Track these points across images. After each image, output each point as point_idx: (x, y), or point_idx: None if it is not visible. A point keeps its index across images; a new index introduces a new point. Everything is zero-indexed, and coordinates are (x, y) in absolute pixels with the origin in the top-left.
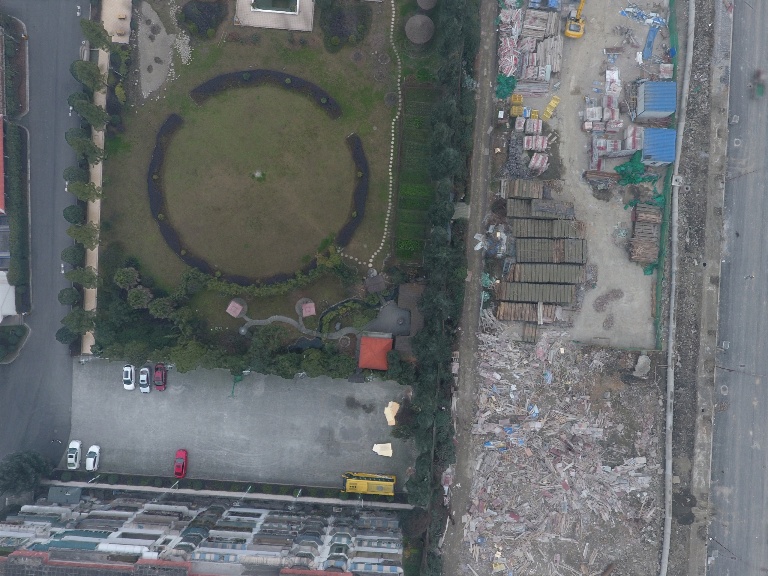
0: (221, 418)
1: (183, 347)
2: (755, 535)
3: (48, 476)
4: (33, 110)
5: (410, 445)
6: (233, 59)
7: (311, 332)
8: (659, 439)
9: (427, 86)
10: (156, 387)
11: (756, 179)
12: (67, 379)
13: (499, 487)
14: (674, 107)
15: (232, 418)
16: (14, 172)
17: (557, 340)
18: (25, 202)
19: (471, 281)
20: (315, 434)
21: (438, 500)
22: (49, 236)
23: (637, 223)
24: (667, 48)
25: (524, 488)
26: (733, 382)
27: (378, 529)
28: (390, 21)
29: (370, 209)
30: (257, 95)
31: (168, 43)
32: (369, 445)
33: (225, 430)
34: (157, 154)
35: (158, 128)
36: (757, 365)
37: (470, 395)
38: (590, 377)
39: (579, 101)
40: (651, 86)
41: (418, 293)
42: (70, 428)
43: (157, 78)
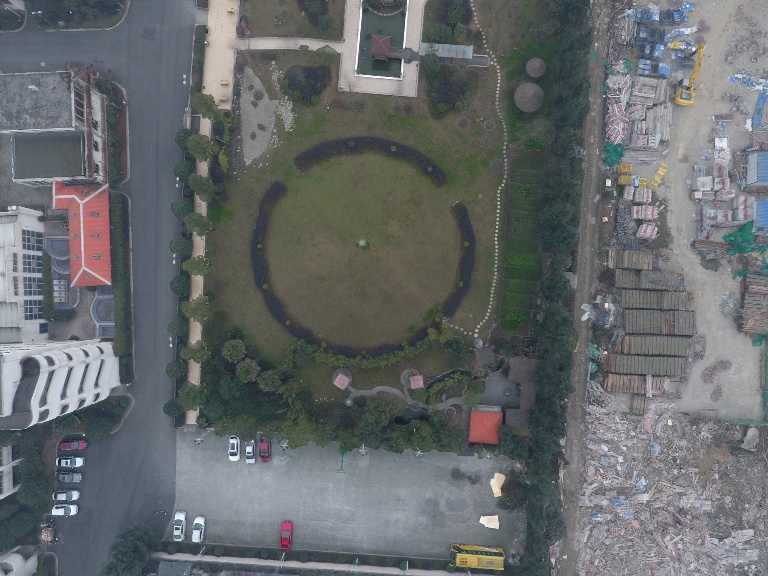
0: (326, 489)
1: (293, 422)
2: None
3: (157, 550)
4: (134, 177)
5: (516, 516)
6: (336, 125)
7: (416, 403)
8: (767, 512)
9: (533, 153)
10: (262, 458)
11: None
12: (171, 449)
13: (606, 559)
14: None
15: (337, 489)
16: (118, 242)
17: (665, 412)
18: (128, 271)
19: (578, 352)
20: (420, 505)
21: None
22: (152, 305)
23: (747, 294)
24: None
25: (631, 560)
26: None
27: None
28: (495, 87)
29: (475, 278)
30: (361, 162)
31: (270, 109)
32: (475, 516)
33: (330, 501)
34: (261, 223)
35: (261, 196)
36: None
37: (577, 467)
38: (698, 449)
39: (687, 169)
40: (764, 157)
41: (529, 367)
42: (174, 499)
43: (260, 145)
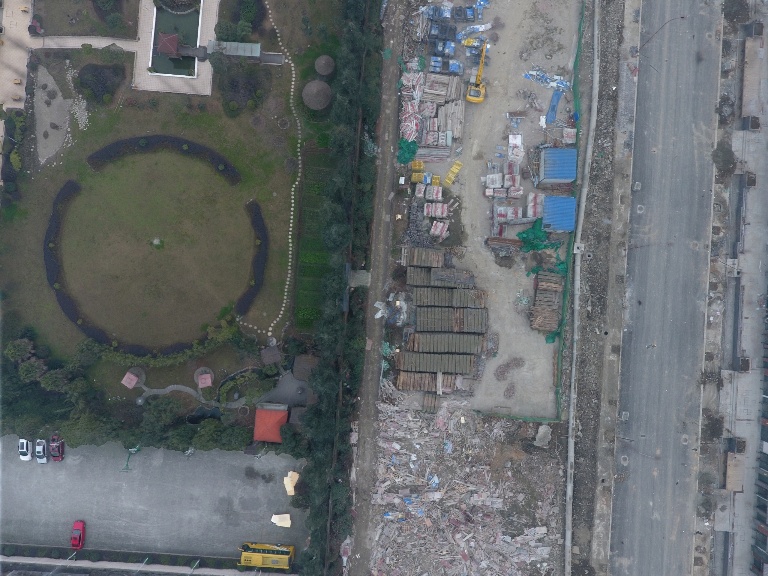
0: (119, 488)
1: (75, 421)
2: None
3: None
4: None
5: None
6: (131, 124)
7: (210, 401)
8: (559, 509)
9: (327, 151)
10: (53, 458)
11: (659, 246)
12: None
13: (398, 558)
14: (574, 175)
15: (130, 488)
16: None
17: (457, 409)
18: None
19: (371, 350)
20: (214, 504)
21: (334, 573)
22: None
23: (538, 291)
24: (571, 112)
25: (424, 558)
26: (633, 452)
27: None
28: (290, 85)
29: (269, 277)
30: (155, 161)
31: (65, 108)
32: (268, 515)
33: (123, 500)
34: (53, 222)
35: (55, 195)
36: (658, 435)
37: (370, 465)
38: (491, 446)
39: (481, 166)
40: (551, 153)
41: (313, 365)
42: None
43: (53, 144)
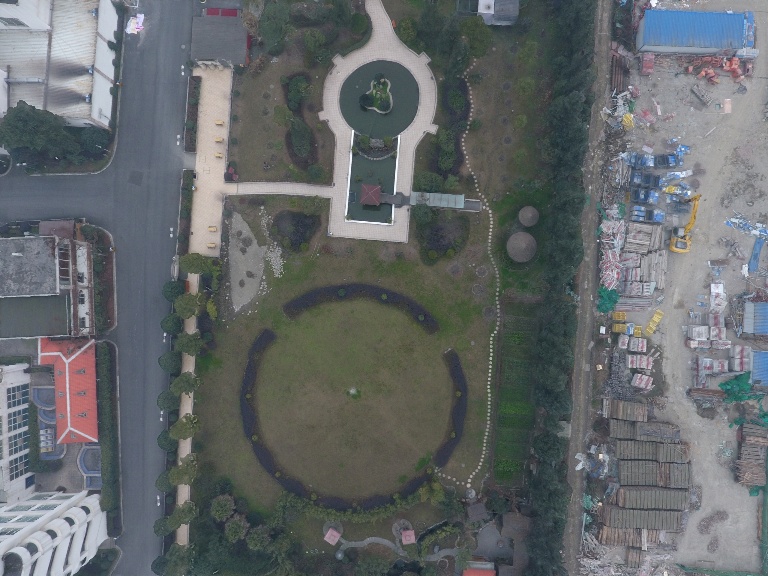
0: None
1: None
2: None
3: None
4: (121, 324)
5: None
6: (326, 271)
7: None
8: None
9: (526, 300)
10: None
11: None
12: None
13: None
14: None
15: None
16: (105, 395)
17: (661, 564)
18: (115, 422)
19: (572, 502)
20: None
21: None
22: (139, 455)
23: (744, 445)
24: None
25: None
26: None
27: None
28: (488, 232)
29: (468, 427)
30: (351, 309)
31: (259, 255)
32: None
33: None
34: (250, 372)
35: (250, 343)
36: None
37: None
38: None
39: (683, 315)
40: (761, 308)
41: (522, 525)
42: None
43: (249, 292)
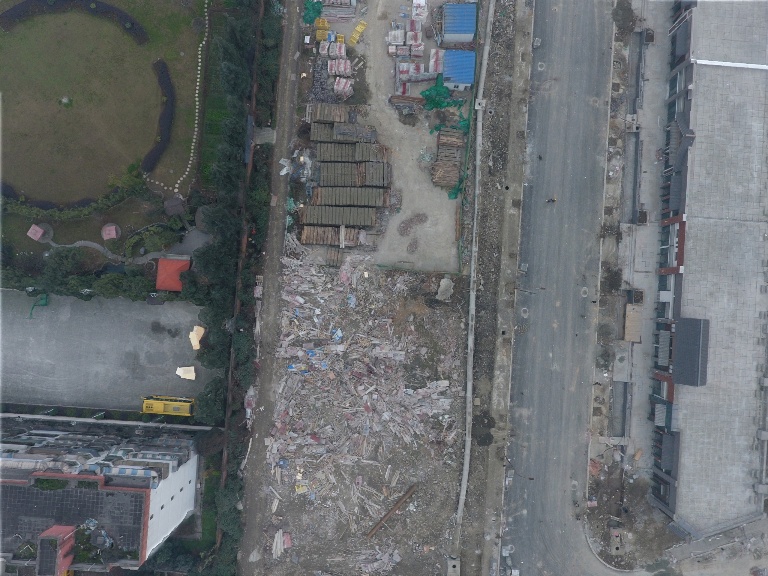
0: (27, 342)
1: None
2: (553, 456)
3: None
4: None
5: (215, 369)
6: None
7: (117, 257)
8: (461, 362)
9: (234, 11)
10: None
11: (559, 103)
12: None
13: (301, 410)
14: (473, 29)
15: (38, 342)
16: None
17: (361, 264)
18: None
19: (276, 206)
20: (120, 358)
21: (235, 421)
22: None
23: (440, 147)
24: None
25: (327, 411)
26: (534, 305)
27: (167, 446)
28: None
29: (176, 134)
30: (64, 21)
31: None
32: (174, 369)
33: (31, 354)
34: None
35: None
36: (558, 288)
37: (274, 319)
38: (394, 301)
39: (386, 26)
40: (451, 8)
41: None
42: None
43: None
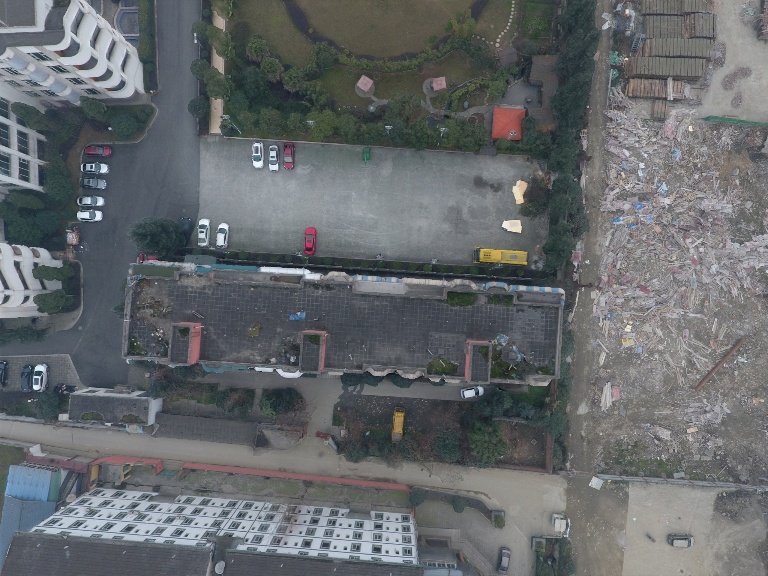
0: (349, 197)
1: None
2: None
3: None
4: None
5: (538, 223)
6: None
7: (439, 111)
8: None
9: None
10: (285, 164)
11: None
12: (195, 159)
13: (628, 263)
14: None
15: (360, 197)
16: None
17: (686, 117)
18: None
19: (599, 60)
20: (443, 213)
21: (571, 270)
22: (175, 17)
23: None
24: None
25: (653, 265)
26: None
27: None
28: None
29: None
30: None
31: None
32: (497, 224)
33: (353, 209)
34: None
35: None
36: None
37: (599, 173)
38: (718, 155)
39: None
40: None
41: (551, 62)
42: (198, 208)
43: None
